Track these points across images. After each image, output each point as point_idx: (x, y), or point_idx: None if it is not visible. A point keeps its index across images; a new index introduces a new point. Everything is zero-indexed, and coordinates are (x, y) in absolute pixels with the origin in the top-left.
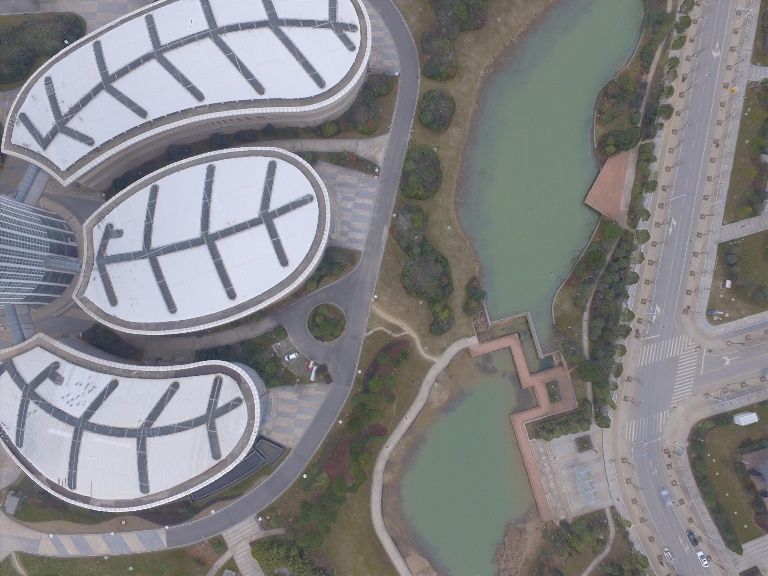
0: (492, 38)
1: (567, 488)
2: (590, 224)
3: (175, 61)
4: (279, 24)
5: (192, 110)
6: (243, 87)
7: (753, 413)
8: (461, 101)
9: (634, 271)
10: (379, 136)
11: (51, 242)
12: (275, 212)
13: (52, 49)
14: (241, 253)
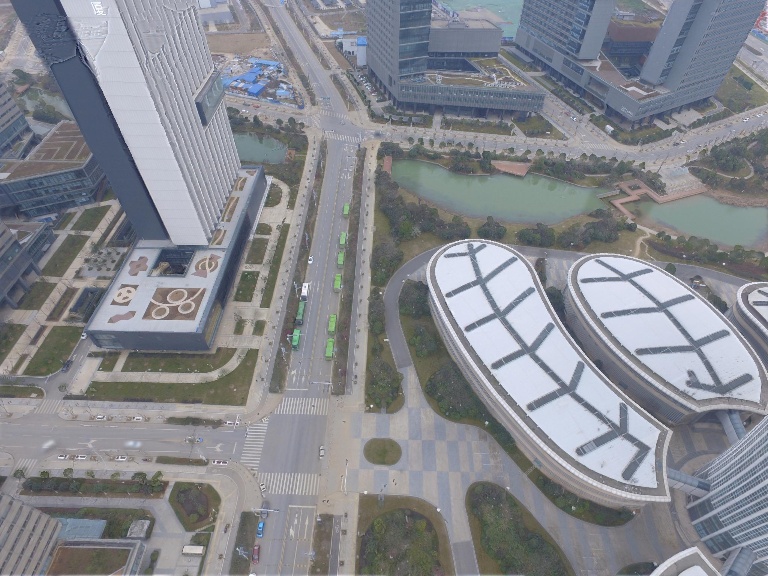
0: None
1: (684, 181)
2: None
3: (532, 338)
4: (481, 279)
5: None
6: (534, 299)
7: (606, 126)
8: None
9: (559, 155)
10: None
11: None
12: None
13: None
14: (660, 289)
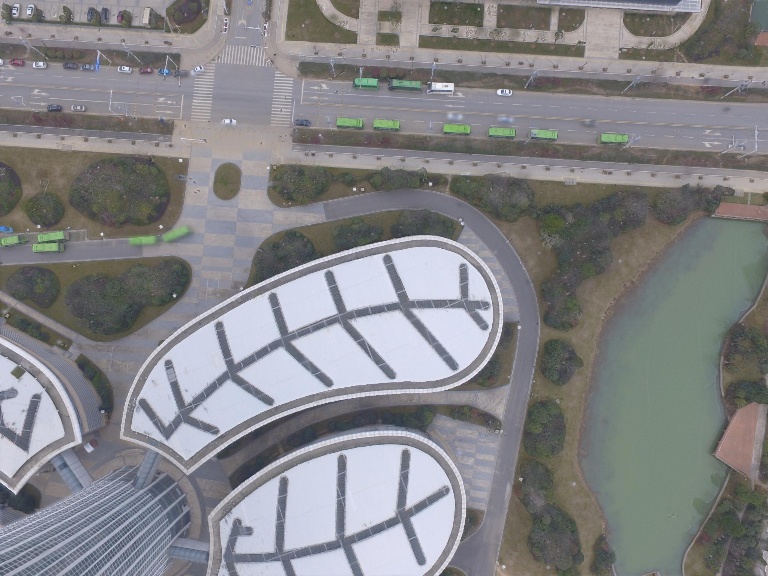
0: (613, 280)
1: None
2: (713, 465)
3: (304, 349)
4: (410, 306)
5: (319, 393)
6: (374, 372)
7: None
8: (583, 348)
9: None
10: (499, 387)
11: (172, 527)
12: (412, 509)
13: (159, 302)
14: (378, 556)
